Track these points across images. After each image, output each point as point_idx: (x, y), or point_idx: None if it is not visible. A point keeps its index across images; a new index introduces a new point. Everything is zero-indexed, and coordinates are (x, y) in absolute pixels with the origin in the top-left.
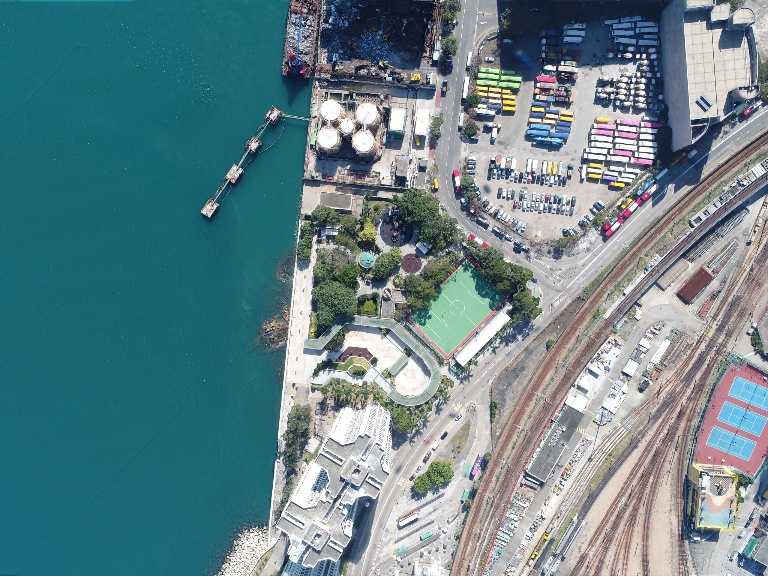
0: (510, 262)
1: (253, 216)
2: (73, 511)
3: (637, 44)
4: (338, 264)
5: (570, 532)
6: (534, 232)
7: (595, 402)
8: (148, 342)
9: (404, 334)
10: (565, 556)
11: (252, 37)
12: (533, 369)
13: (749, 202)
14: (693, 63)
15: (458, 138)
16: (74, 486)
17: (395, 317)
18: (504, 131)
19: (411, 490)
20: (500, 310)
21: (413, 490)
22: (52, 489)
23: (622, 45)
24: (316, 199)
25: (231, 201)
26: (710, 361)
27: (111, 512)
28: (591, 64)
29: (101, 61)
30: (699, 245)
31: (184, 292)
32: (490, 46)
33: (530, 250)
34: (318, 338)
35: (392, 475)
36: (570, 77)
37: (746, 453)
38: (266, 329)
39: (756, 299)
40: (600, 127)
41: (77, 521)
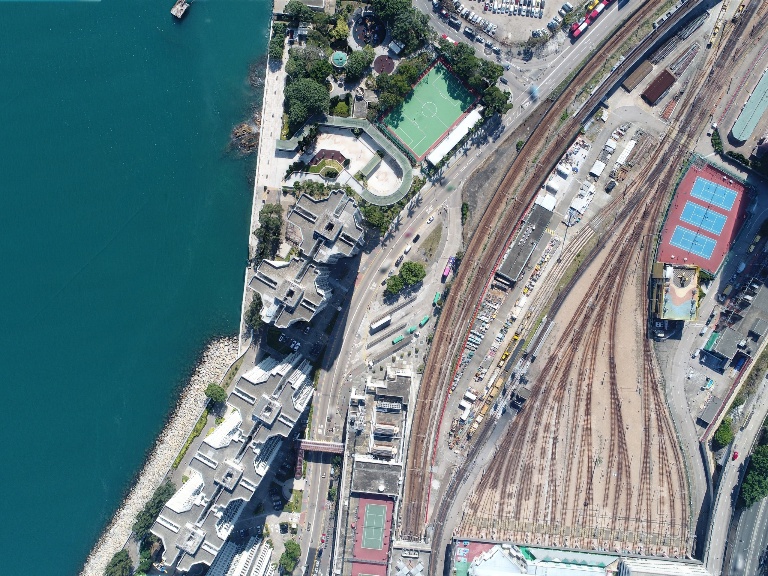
0: (481, 58)
1: (224, 18)
2: (35, 308)
3: None
4: (311, 57)
5: (540, 331)
6: (504, 34)
7: (564, 203)
8: (115, 132)
9: (377, 134)
10: (535, 355)
11: None
12: (504, 171)
13: (709, 6)
14: None
15: None
16: (36, 282)
17: (368, 116)
18: None
19: (383, 294)
20: None
21: (385, 294)
22: (13, 285)
23: None
24: None
25: (202, 1)
26: (673, 162)
27: (75, 308)
28: None
29: None
30: (662, 47)
31: (153, 79)
32: None
33: (501, 52)
34: (290, 139)
35: (364, 279)
36: None
37: (707, 252)
38: (237, 133)
39: (716, 101)
40: None
41: (39, 318)
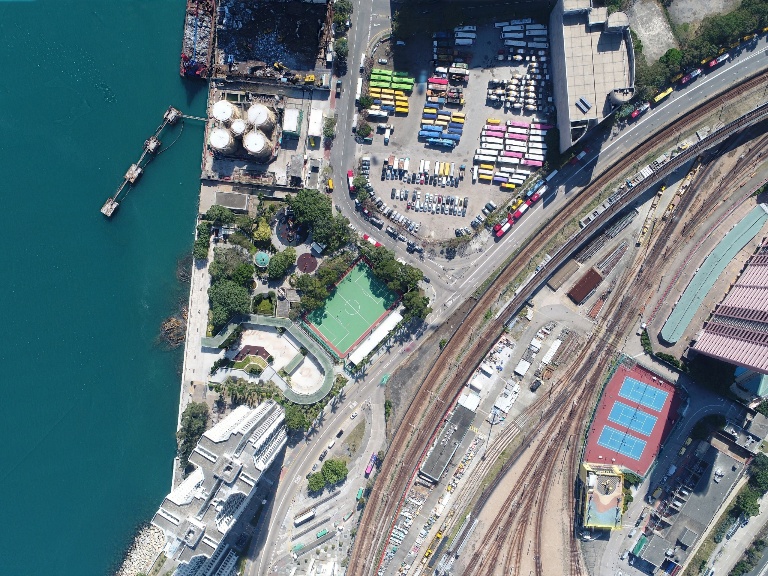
0: (401, 262)
1: (152, 215)
2: None
3: (527, 46)
4: (231, 263)
5: (463, 530)
6: (427, 232)
7: (488, 401)
8: (42, 340)
9: (299, 333)
10: (458, 554)
11: (151, 38)
12: (427, 368)
13: (638, 204)
14: (572, 66)
15: (353, 139)
16: None
17: (289, 316)
18: (398, 132)
19: (308, 488)
20: (394, 310)
21: None
22: None
23: (512, 47)
24: (213, 199)
25: (130, 200)
26: (601, 361)
27: (6, 508)
28: (483, 66)
29: (1, 61)
30: (589, 246)
31: (77, 290)
32: (384, 48)
33: (423, 250)
34: (215, 337)
35: (289, 473)
36: (461, 79)
37: (636, 452)
38: (165, 327)
39: (645, 300)
40: (491, 129)
41: None
